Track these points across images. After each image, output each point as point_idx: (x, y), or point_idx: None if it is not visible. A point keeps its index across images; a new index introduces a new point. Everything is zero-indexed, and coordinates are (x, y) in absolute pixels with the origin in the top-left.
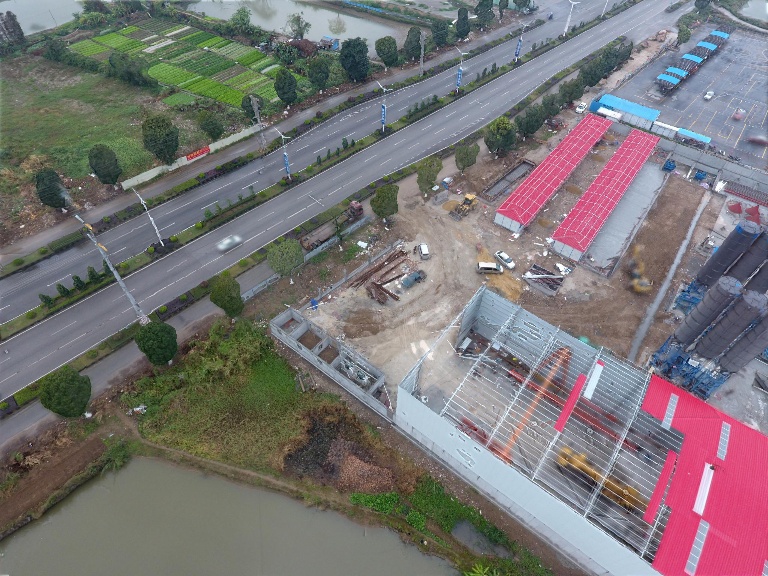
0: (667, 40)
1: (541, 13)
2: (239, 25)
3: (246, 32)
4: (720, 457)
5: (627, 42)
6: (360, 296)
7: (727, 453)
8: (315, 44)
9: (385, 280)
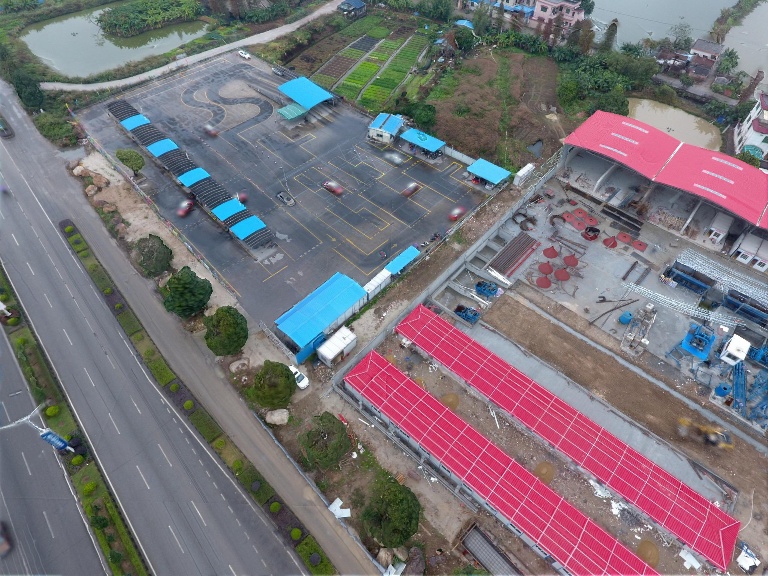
0: (106, 176)
1: None
2: None
3: None
4: None
5: (82, 224)
6: None
7: None
8: None
9: None
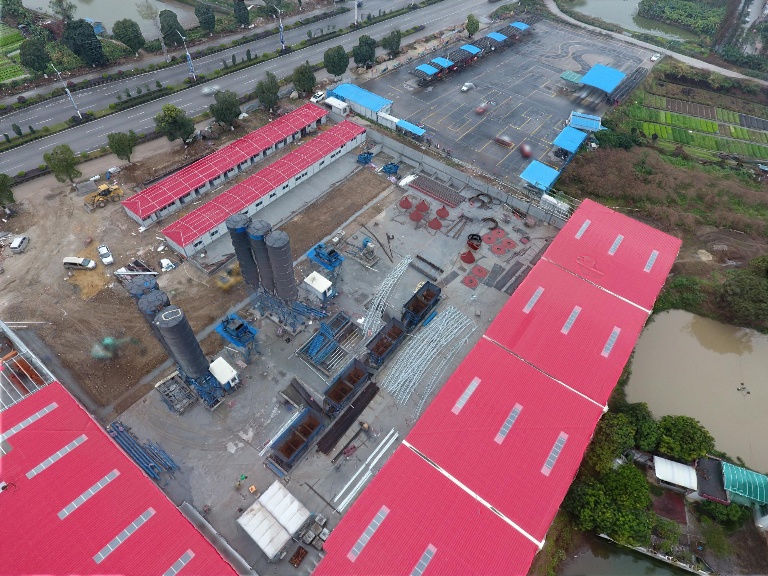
0: None
1: (354, 1)
2: (1, 6)
3: (11, 13)
4: (29, 475)
5: (423, 32)
6: None
7: (43, 471)
8: None
9: None
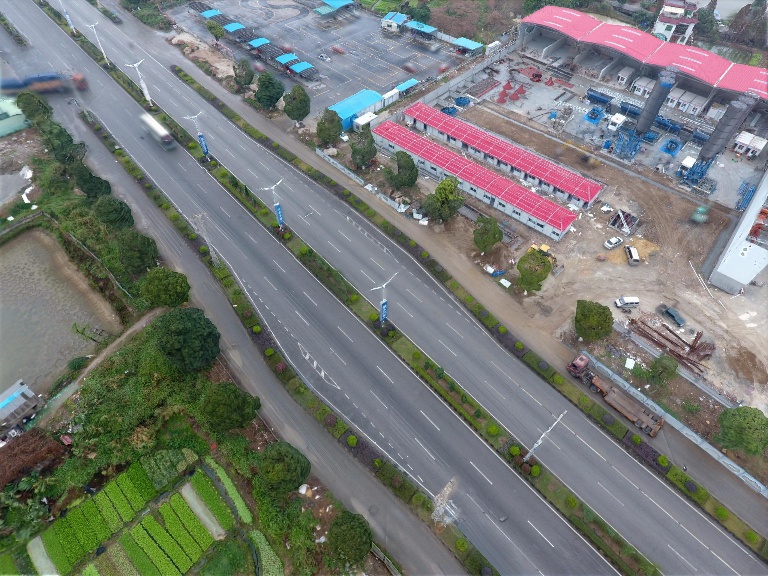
0: None
1: (52, 108)
2: None
3: None
4: None
5: (185, 68)
6: (713, 367)
7: None
8: (6, 438)
9: (679, 343)
